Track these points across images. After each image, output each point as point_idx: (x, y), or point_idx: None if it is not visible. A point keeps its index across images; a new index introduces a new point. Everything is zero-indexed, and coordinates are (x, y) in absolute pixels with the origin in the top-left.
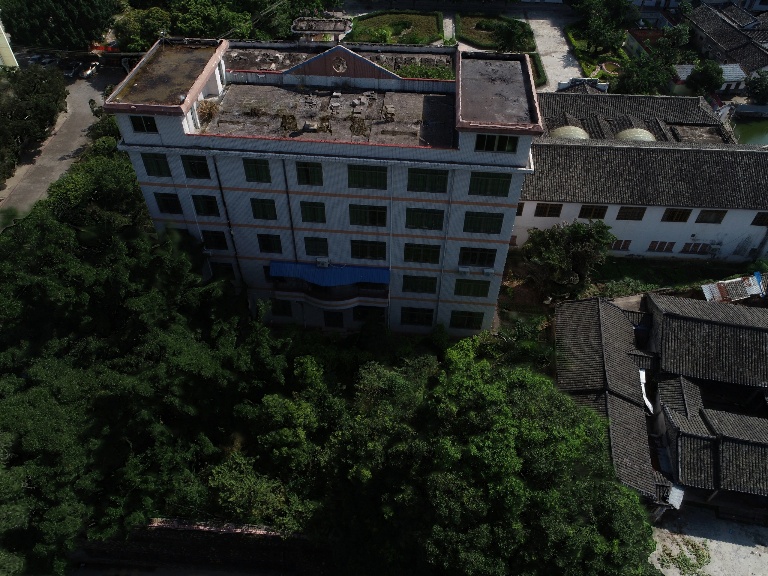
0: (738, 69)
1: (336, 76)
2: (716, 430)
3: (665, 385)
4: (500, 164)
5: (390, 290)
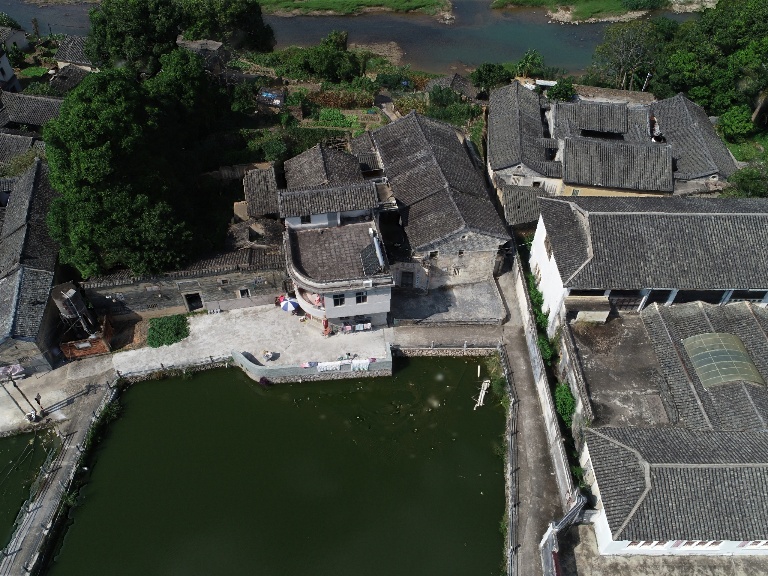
0: None
1: None
2: (626, 111)
3: None
4: None
5: None
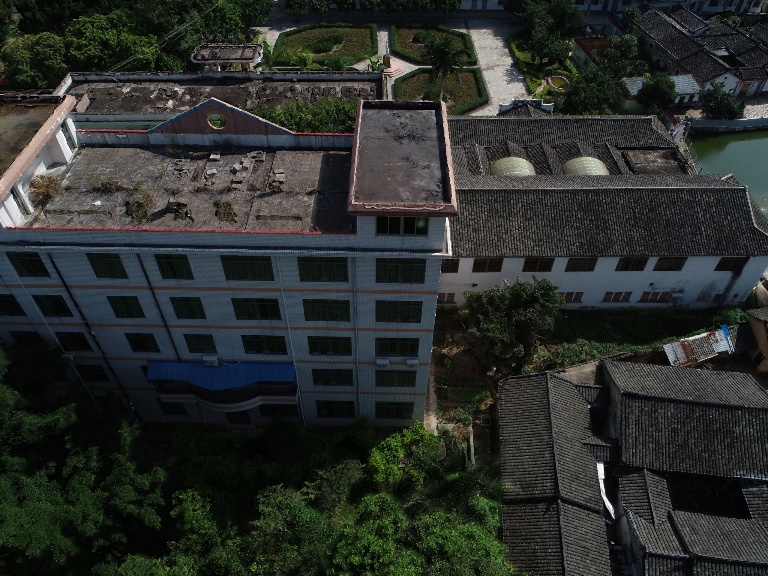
0: (691, 80)
1: (214, 133)
2: (688, 545)
3: (627, 481)
4: (410, 248)
5: (299, 384)
